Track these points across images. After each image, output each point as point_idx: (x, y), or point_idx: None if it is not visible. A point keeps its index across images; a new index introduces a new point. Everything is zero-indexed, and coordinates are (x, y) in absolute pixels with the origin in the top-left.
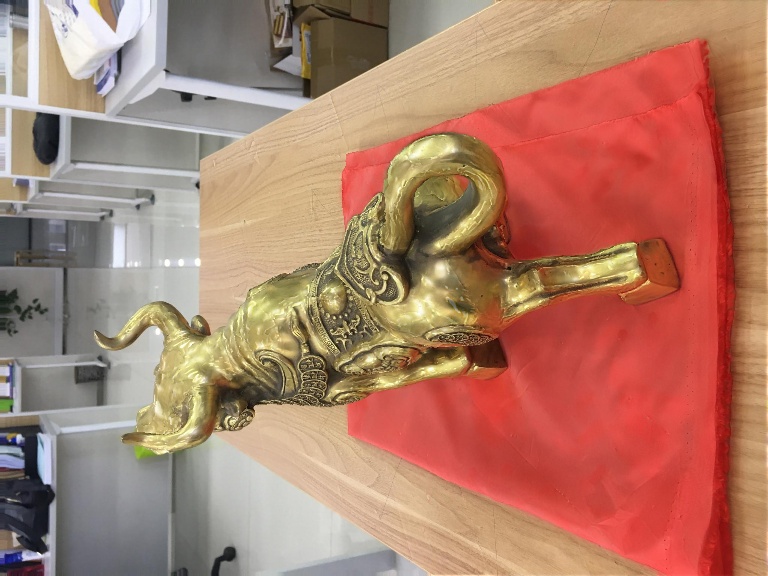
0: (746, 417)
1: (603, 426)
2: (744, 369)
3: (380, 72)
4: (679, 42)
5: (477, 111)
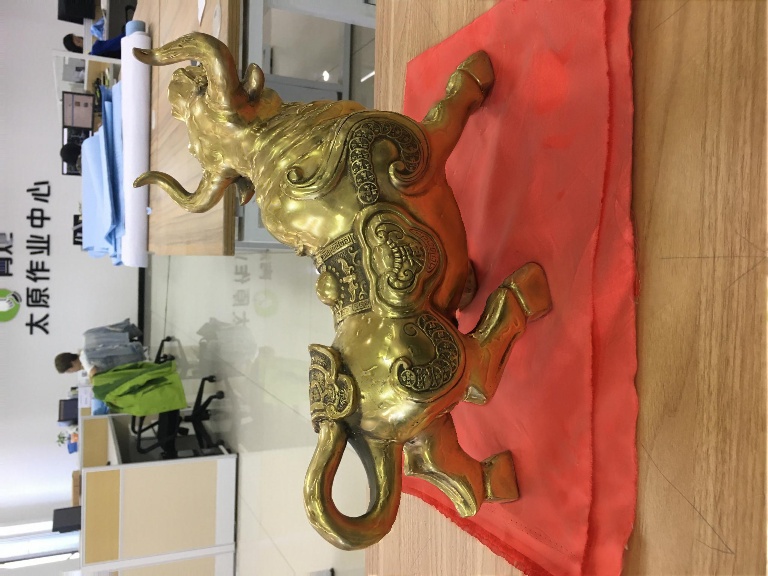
0: None
1: None
2: None
3: None
4: (636, 574)
5: (634, 275)
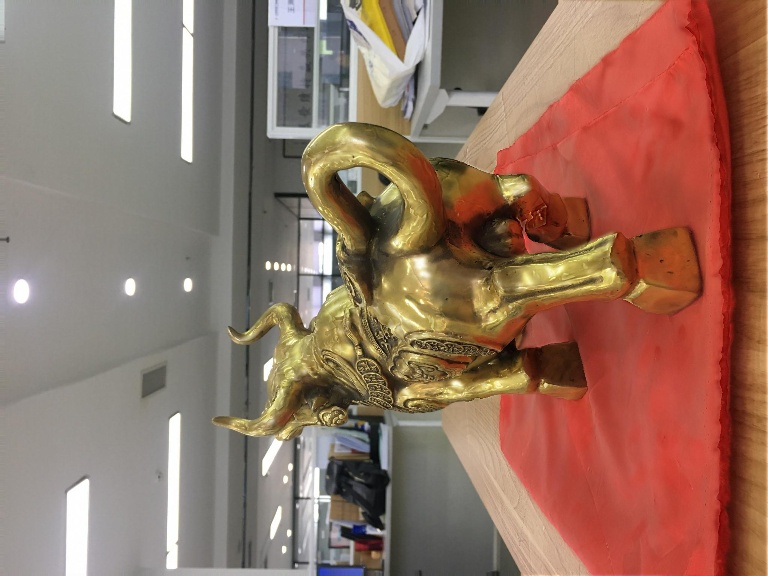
0: (755, 478)
1: (647, 469)
2: (753, 408)
3: (525, 61)
4: None
5: (569, 90)
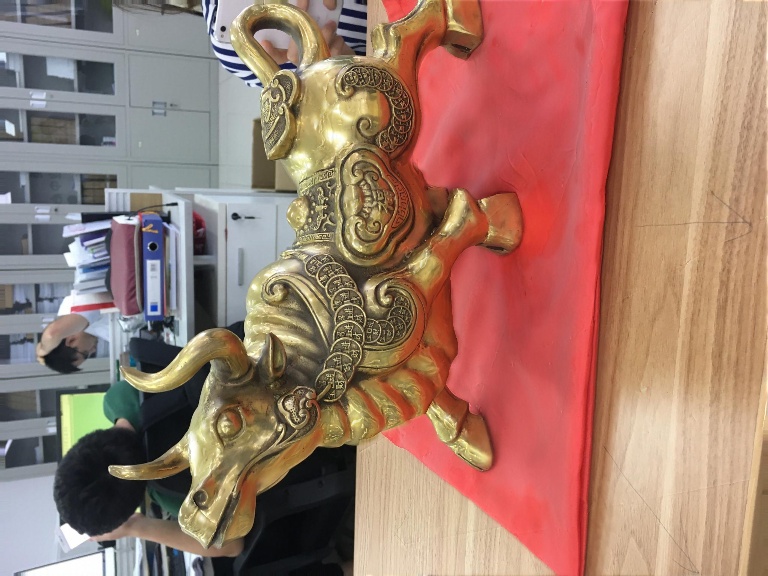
0: None
1: (550, 52)
2: None
3: None
4: None
5: None
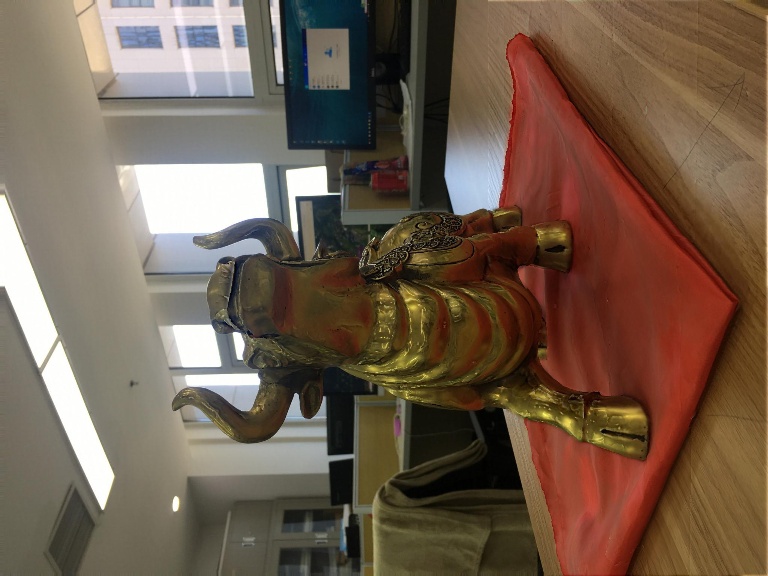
0: None
1: None
2: None
3: None
4: None
5: (527, 429)
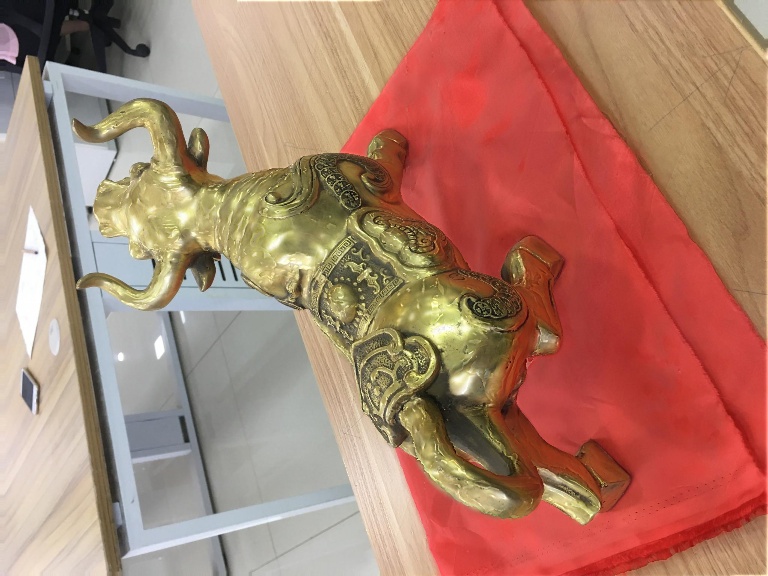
0: None
1: None
2: None
3: None
4: None
5: (634, 156)
